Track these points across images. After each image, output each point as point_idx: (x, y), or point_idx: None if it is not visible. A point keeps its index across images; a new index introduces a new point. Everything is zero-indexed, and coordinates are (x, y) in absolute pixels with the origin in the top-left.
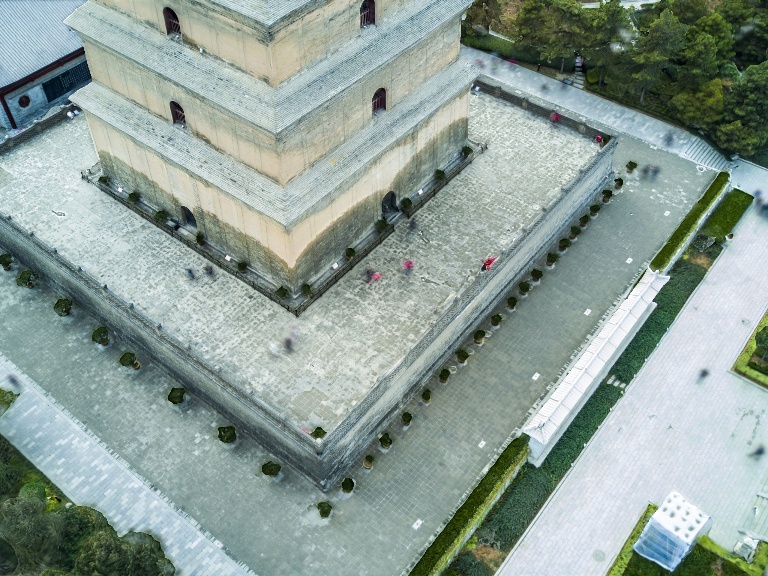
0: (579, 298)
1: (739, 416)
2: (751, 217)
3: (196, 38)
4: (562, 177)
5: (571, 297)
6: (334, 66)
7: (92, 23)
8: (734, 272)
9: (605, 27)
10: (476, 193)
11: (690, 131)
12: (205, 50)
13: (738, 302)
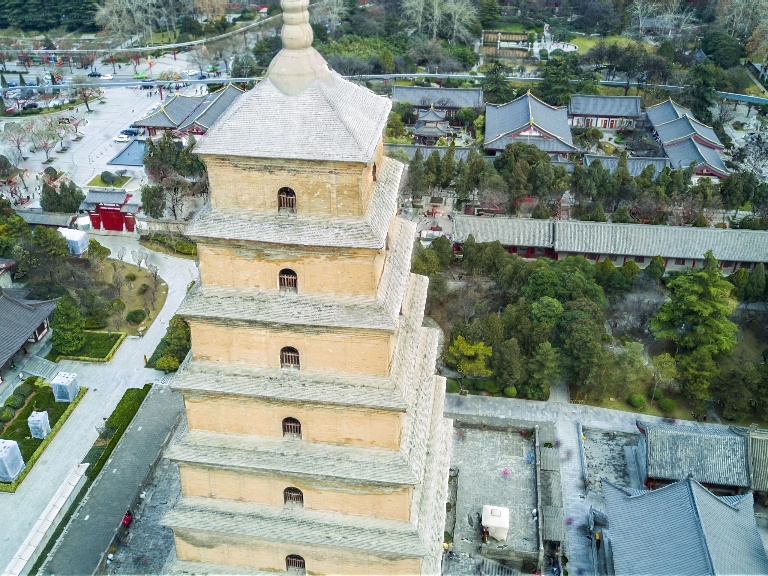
0: None
1: None
2: None
3: None
4: None
5: None
6: None
7: None
8: None
9: None
10: None
11: None
12: None
13: None
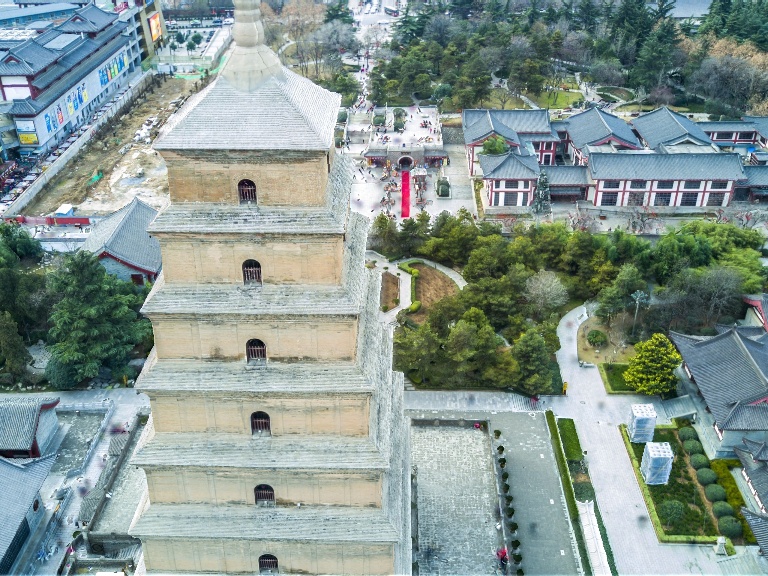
0: (550, 546)
1: (689, 571)
2: (581, 433)
3: (294, 498)
4: (480, 465)
5: (545, 548)
6: (388, 470)
7: (165, 523)
8: (604, 476)
9: (424, 345)
10: (442, 506)
11: (504, 391)
12: (303, 503)
13: (624, 495)
